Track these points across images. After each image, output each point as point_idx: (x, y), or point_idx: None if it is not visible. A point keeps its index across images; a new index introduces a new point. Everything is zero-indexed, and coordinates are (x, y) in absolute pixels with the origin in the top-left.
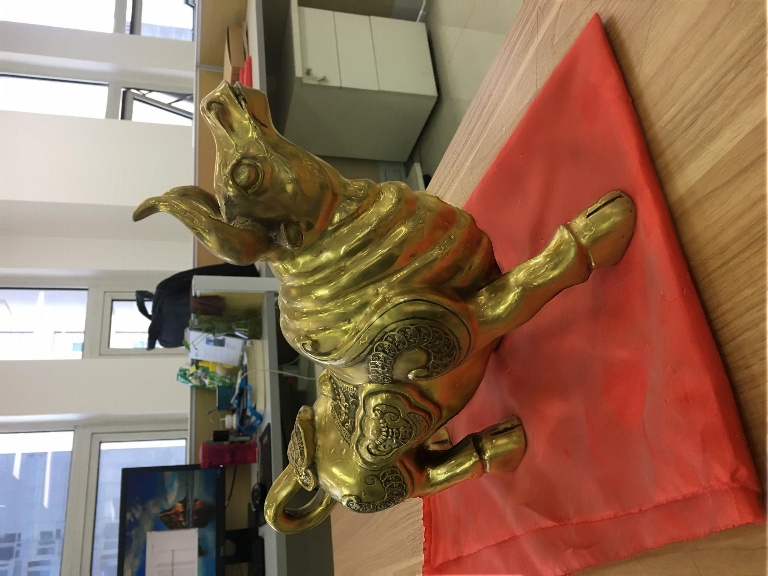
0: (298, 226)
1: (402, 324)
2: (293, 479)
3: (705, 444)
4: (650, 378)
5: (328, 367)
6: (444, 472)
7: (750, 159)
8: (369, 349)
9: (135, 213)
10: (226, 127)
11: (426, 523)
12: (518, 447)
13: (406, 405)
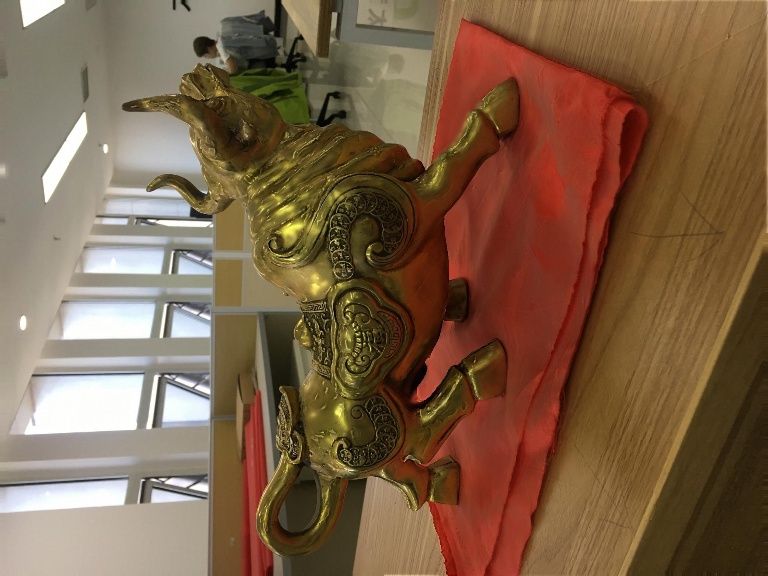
0: None
1: (349, 194)
2: (284, 473)
3: (587, 105)
4: None
5: (296, 276)
6: (433, 407)
7: None
8: (326, 227)
9: (124, 104)
10: (198, 86)
11: (451, 575)
12: (498, 356)
13: (374, 306)
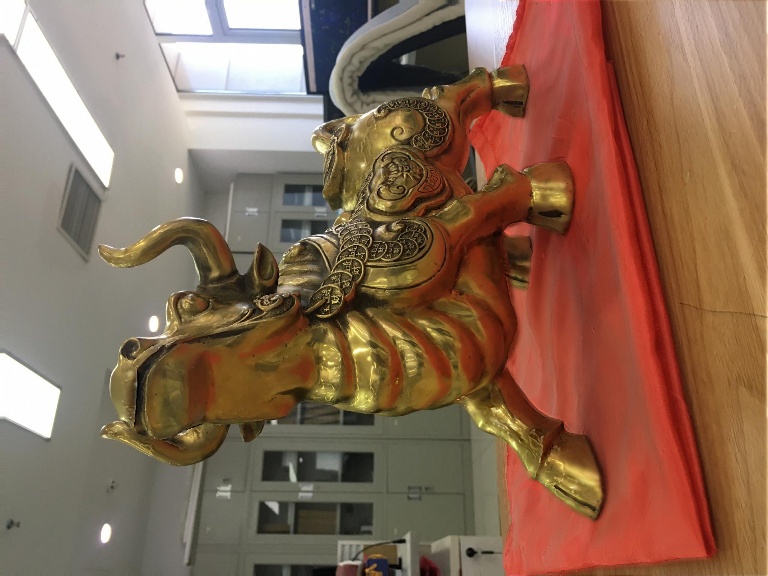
0: None
1: None
2: None
3: (512, 559)
4: (538, 500)
5: None
6: None
7: None
8: None
9: None
10: None
11: None
12: None
13: None
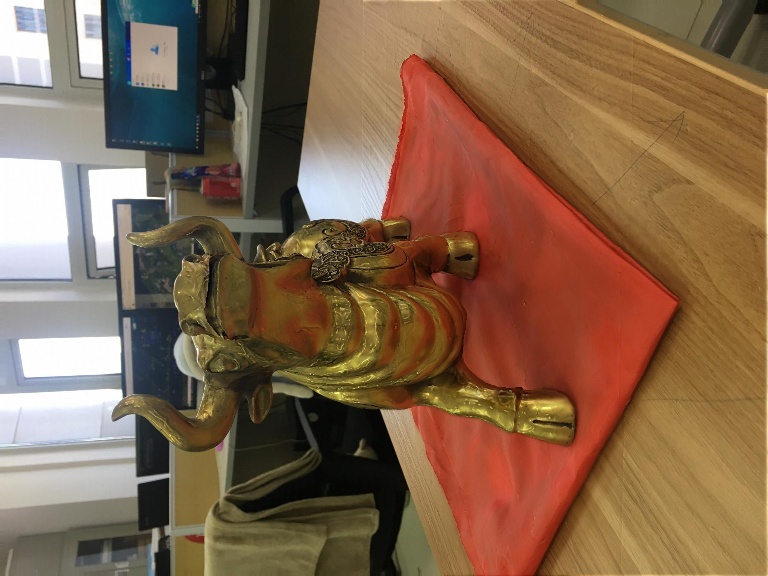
0: (271, 373)
1: None
2: None
3: None
4: (507, 509)
5: None
6: None
7: (625, 574)
8: None
9: (114, 418)
10: None
11: None
12: None
13: None
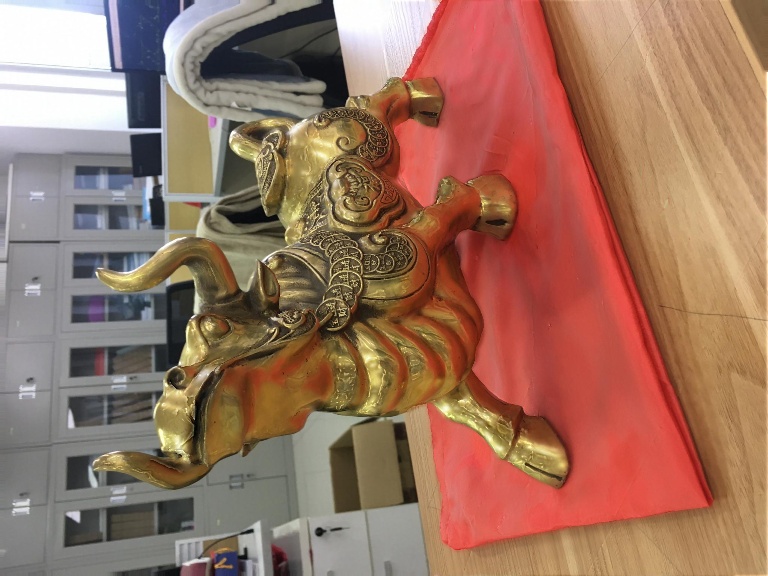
0: None
1: None
2: None
3: (455, 532)
4: (481, 477)
5: None
6: None
7: None
8: None
9: None
10: (189, 443)
11: None
12: None
13: None
